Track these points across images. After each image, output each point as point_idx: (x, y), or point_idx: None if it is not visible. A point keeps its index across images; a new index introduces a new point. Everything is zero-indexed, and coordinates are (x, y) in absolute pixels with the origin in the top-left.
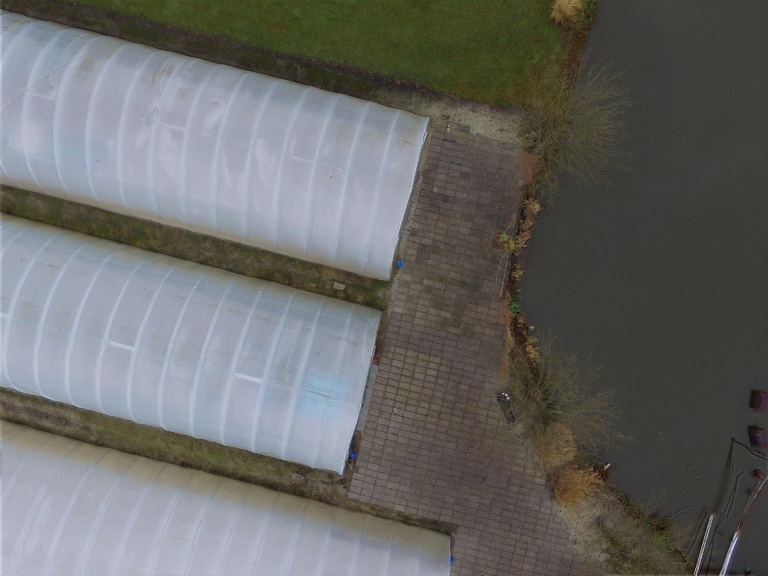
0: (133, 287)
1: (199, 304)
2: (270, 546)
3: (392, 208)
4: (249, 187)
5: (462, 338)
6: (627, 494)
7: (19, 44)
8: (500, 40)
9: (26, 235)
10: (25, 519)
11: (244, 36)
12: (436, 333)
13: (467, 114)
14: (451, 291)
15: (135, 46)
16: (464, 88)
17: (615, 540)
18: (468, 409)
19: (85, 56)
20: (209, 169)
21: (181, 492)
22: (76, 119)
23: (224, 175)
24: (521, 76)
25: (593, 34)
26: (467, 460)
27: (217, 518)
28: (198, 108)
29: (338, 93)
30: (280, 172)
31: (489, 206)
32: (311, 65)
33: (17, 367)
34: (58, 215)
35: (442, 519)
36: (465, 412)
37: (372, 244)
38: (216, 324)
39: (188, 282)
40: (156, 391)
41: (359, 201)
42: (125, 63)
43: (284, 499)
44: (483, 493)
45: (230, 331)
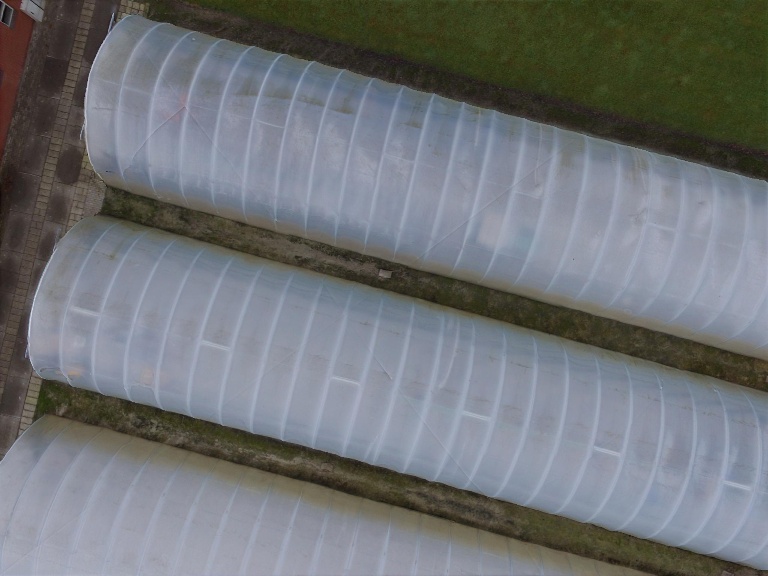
0: (605, 388)
1: (673, 406)
2: None
3: None
4: (734, 289)
5: None
6: None
7: (496, 139)
8: None
9: None
10: None
11: (673, 124)
12: None
13: None
14: None
15: (590, 138)
16: None
17: None
18: None
19: (561, 152)
20: (695, 270)
21: None
22: (561, 218)
23: (710, 277)
24: None
25: None
26: None
27: None
28: (686, 208)
29: None
30: None
31: None
32: (741, 154)
33: (489, 470)
34: (484, 304)
35: None
36: None
37: None
38: (698, 429)
39: (648, 381)
40: (638, 497)
41: None
42: (600, 159)
43: None
44: None
45: (713, 436)
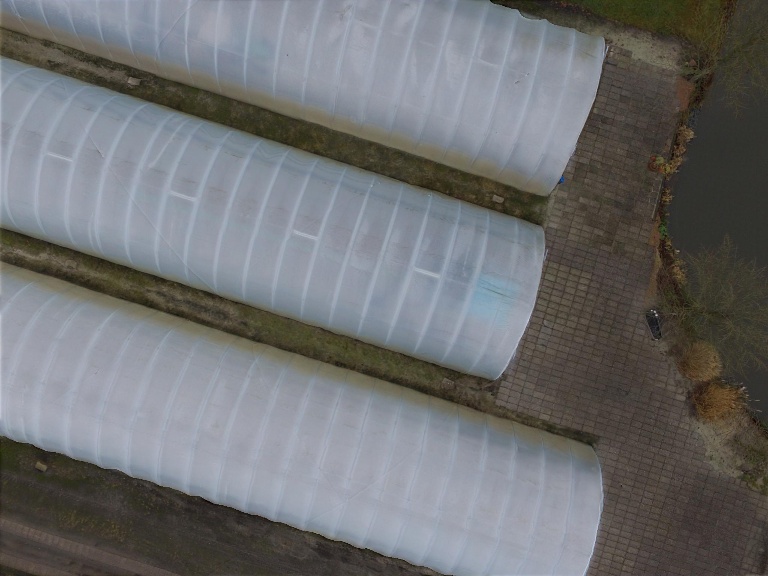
0: (314, 181)
1: (378, 201)
2: (433, 439)
3: (574, 116)
4: (435, 88)
5: (613, 256)
6: (760, 416)
7: None
8: None
9: (204, 128)
10: (201, 399)
11: None
12: (589, 250)
13: (630, 40)
14: (605, 210)
15: None
16: (628, 14)
17: (749, 458)
18: (615, 325)
19: None
20: (398, 68)
21: (343, 386)
22: (272, 12)
23: (412, 75)
24: (683, 6)
25: None
26: (612, 374)
27: (381, 411)
28: (391, 8)
29: None
30: (468, 75)
31: (646, 130)
32: None
33: (198, 252)
34: (227, 114)
35: (585, 430)
36: (612, 327)
37: (547, 152)
38: (396, 220)
39: (363, 181)
40: (335, 281)
41: (542, 107)
42: None
43: (435, 402)
44: (625, 406)
45: (409, 227)
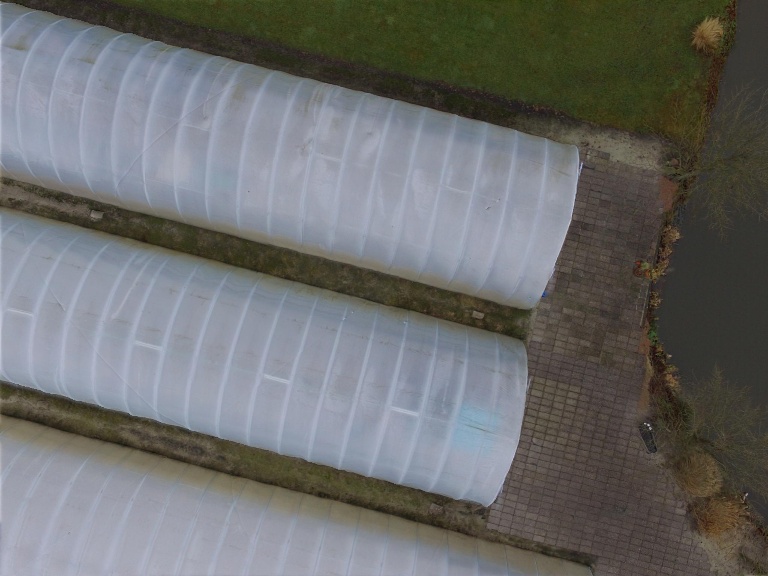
0: (284, 319)
1: (350, 336)
2: None
3: (550, 240)
4: (404, 218)
5: (602, 367)
6: (766, 524)
7: (170, 74)
8: (640, 66)
9: (169, 265)
10: (178, 554)
11: (381, 62)
12: (576, 362)
13: (607, 141)
14: (591, 320)
15: (279, 74)
16: (604, 115)
17: (757, 571)
18: (608, 439)
19: (236, 86)
20: (364, 200)
21: (326, 524)
22: (230, 150)
23: (379, 206)
24: (661, 102)
25: (731, 59)
26: (607, 490)
27: (366, 551)
28: (353, 139)
29: (477, 120)
30: (437, 204)
31: (629, 234)
32: (448, 91)
33: (168, 400)
34: (194, 243)
35: (582, 550)
36: (605, 442)
37: (525, 275)
38: (370, 357)
39: (335, 313)
40: (310, 424)
41: (516, 233)
42: (276, 93)
43: (424, 530)
44: (623, 524)
45: (384, 364)
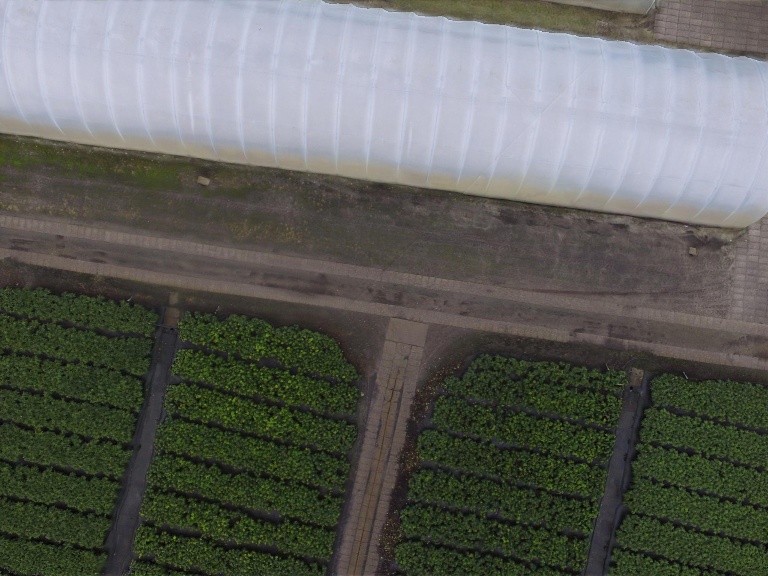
0: None
1: None
2: (611, 49)
3: None
4: None
5: None
6: None
7: None
8: None
9: None
10: (371, 39)
11: None
12: None
13: None
14: None
15: None
16: None
17: None
18: None
19: None
20: None
21: (504, 25)
22: None
23: None
24: None
25: None
26: None
27: (550, 36)
28: None
29: None
30: None
31: None
32: None
33: None
34: None
35: (749, 49)
36: None
37: None
38: None
39: None
40: None
41: None
42: None
43: None
44: None
45: None
